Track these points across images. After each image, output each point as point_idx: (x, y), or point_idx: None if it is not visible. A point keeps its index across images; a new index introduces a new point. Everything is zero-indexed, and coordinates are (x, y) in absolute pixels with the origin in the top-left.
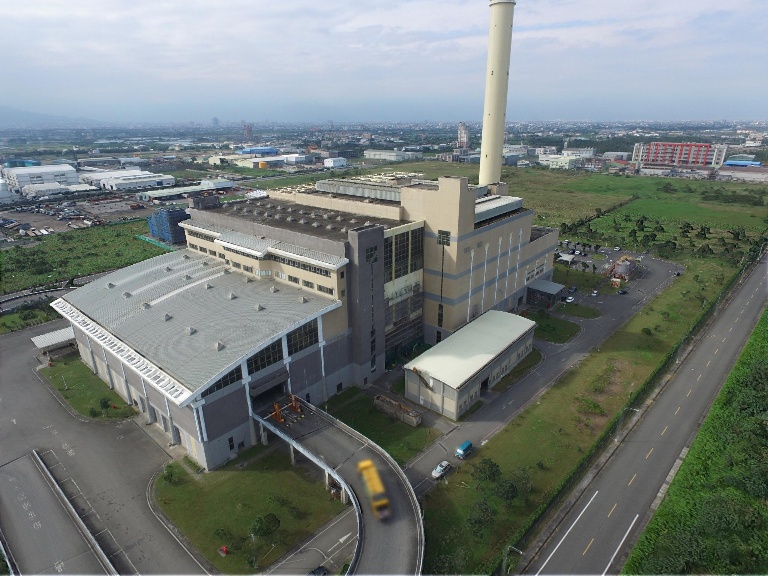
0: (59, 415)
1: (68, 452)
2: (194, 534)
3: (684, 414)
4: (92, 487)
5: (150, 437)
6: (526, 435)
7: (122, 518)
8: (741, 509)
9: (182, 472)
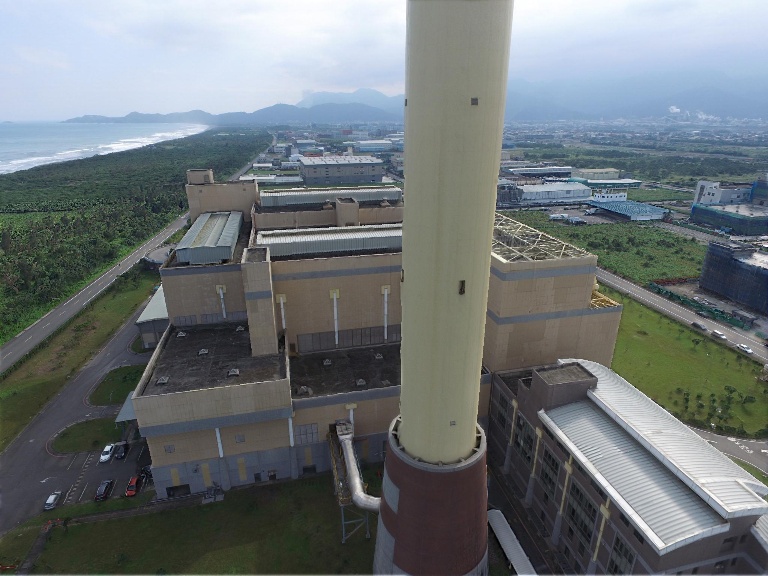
0: None
1: None
2: None
3: (3, 354)
4: None
5: None
6: (127, 304)
7: None
8: (7, 311)
9: None
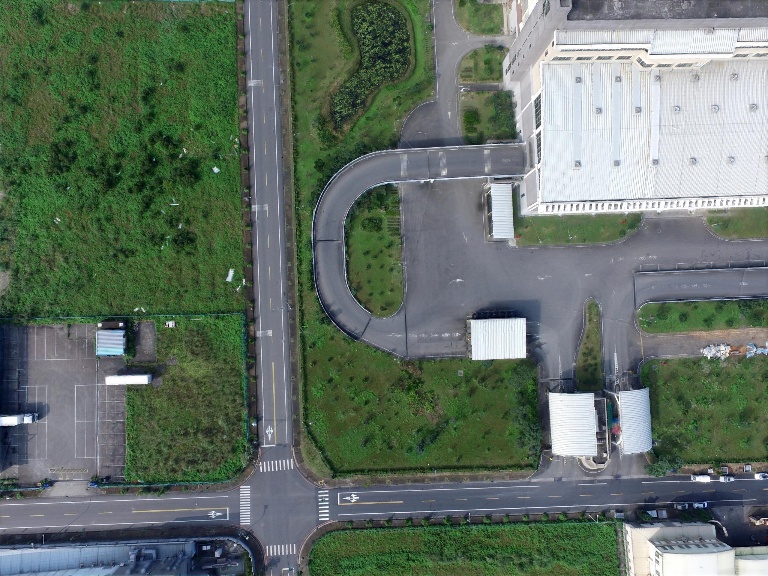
0: (603, 252)
1: (651, 258)
2: (764, 233)
3: None
4: (694, 258)
5: (673, 218)
6: None
7: (728, 254)
8: None
9: (720, 218)
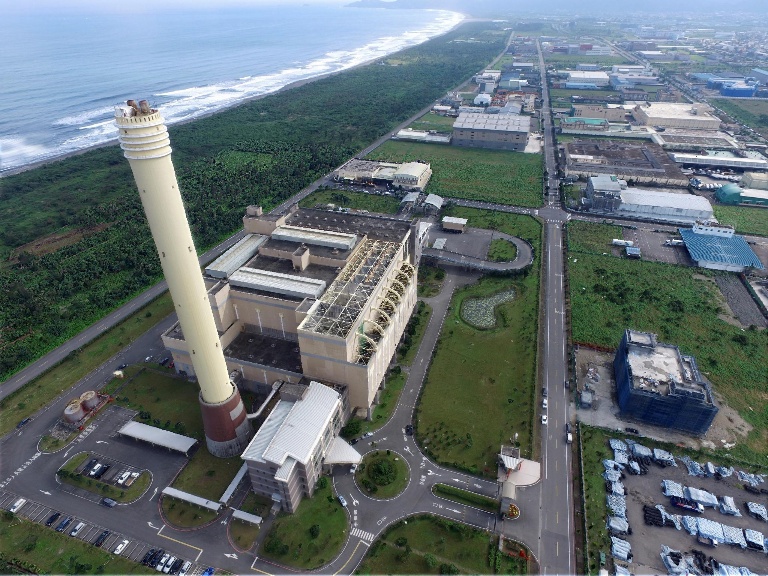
0: None
1: None
2: None
3: None
4: None
5: None
6: None
7: None
8: None
9: None
